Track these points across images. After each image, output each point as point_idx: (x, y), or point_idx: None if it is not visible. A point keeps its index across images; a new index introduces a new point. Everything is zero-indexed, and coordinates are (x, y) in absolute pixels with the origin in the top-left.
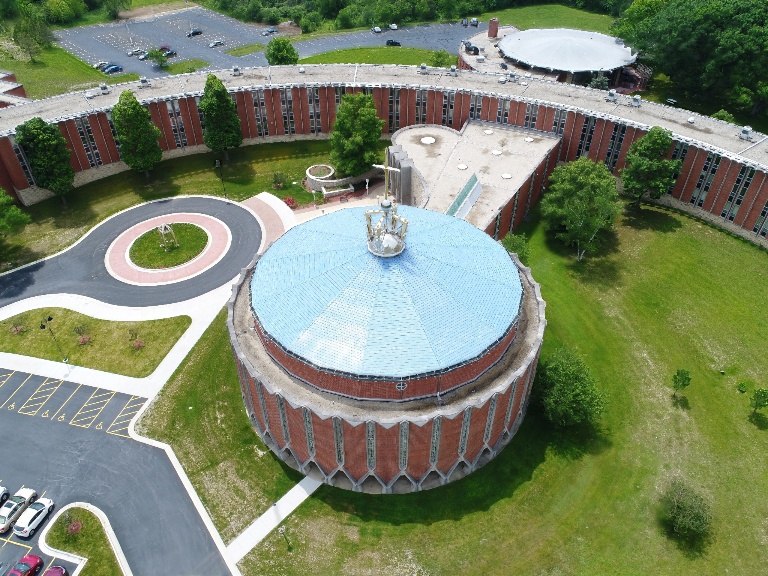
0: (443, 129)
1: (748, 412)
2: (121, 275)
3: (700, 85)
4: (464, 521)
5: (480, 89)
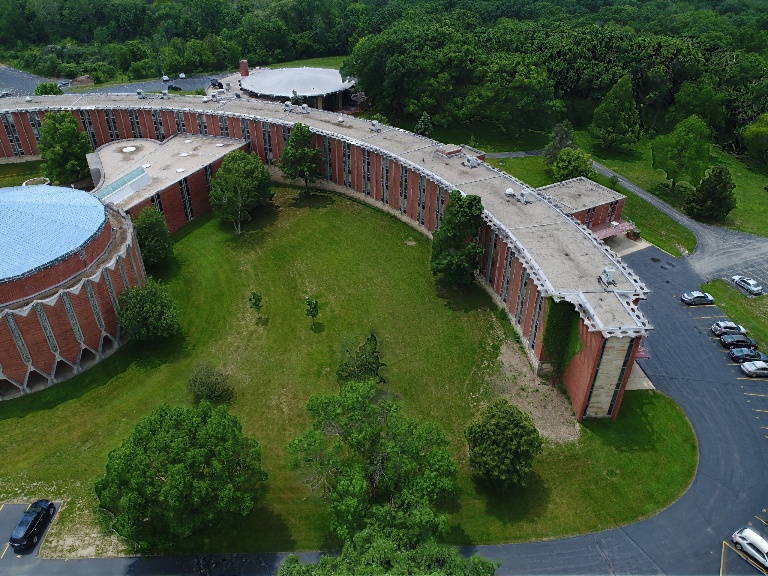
0: (149, 141)
1: (312, 323)
2: None
3: None
4: (27, 417)
5: (181, 107)
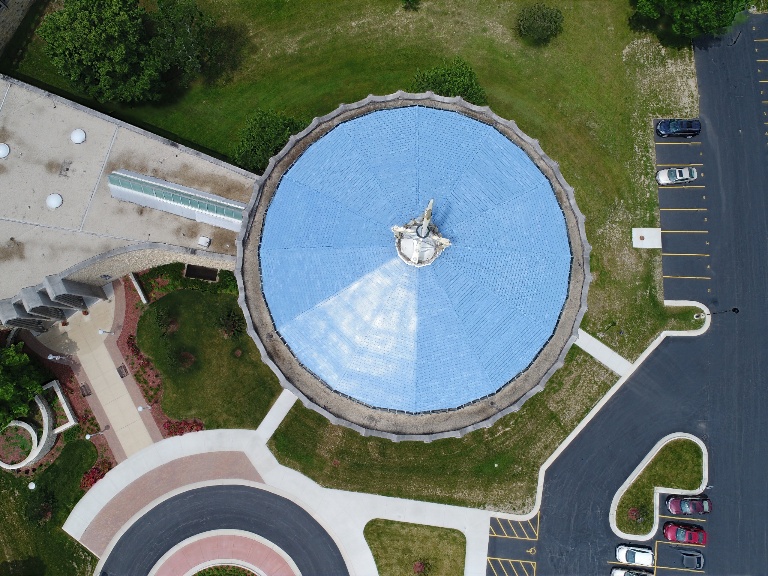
0: None
1: None
2: None
3: None
4: None
5: None
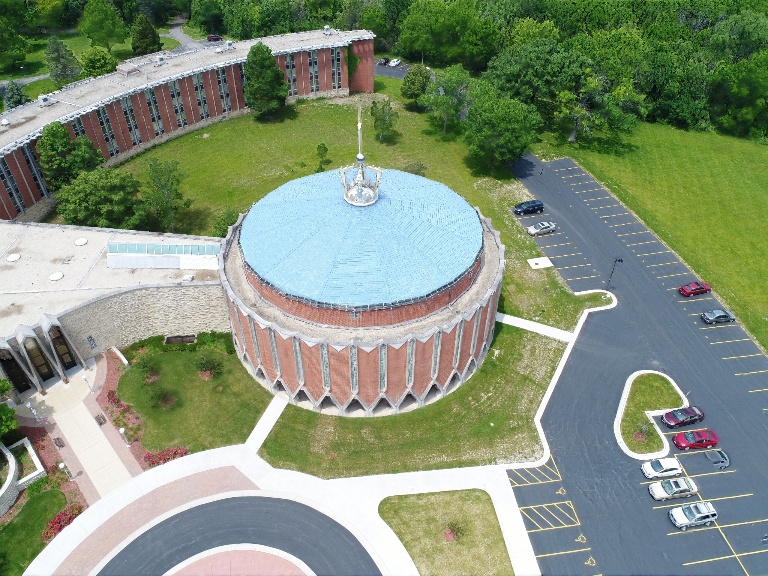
0: None
1: None
2: None
3: None
4: None
5: None
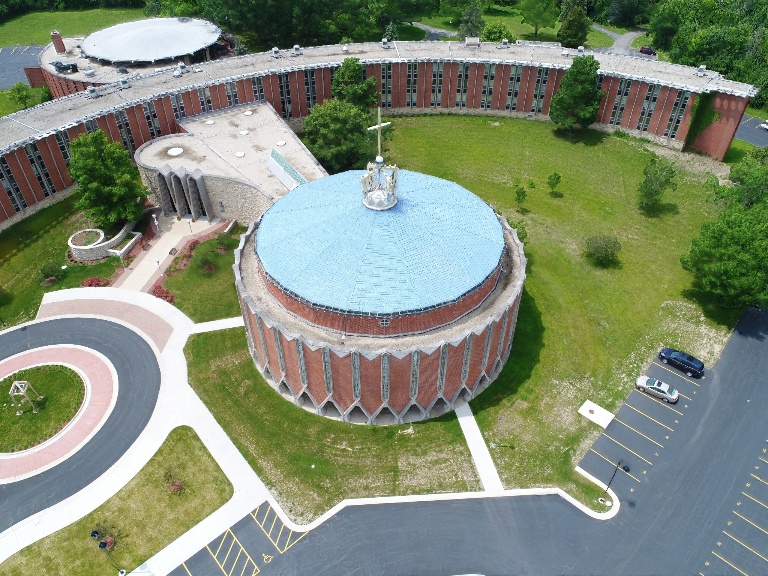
0: (170, 138)
1: (548, 194)
2: (23, 472)
3: (295, 29)
4: (547, 343)
5: (172, 88)
